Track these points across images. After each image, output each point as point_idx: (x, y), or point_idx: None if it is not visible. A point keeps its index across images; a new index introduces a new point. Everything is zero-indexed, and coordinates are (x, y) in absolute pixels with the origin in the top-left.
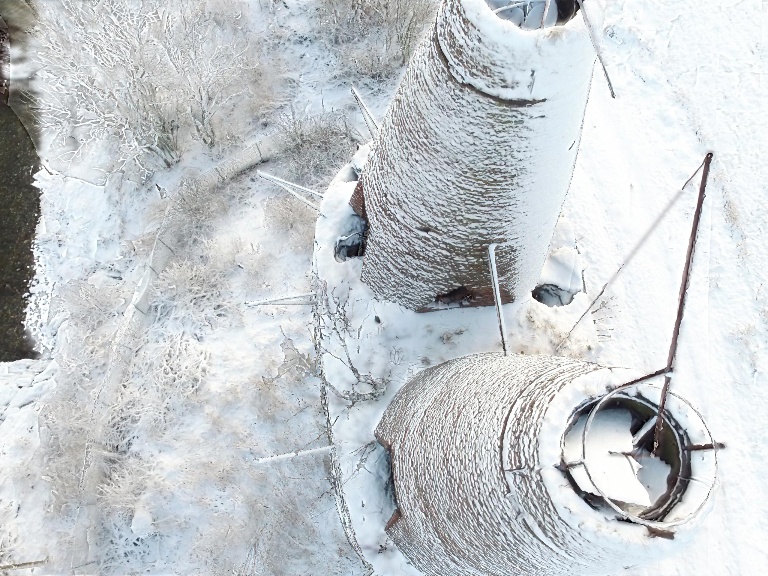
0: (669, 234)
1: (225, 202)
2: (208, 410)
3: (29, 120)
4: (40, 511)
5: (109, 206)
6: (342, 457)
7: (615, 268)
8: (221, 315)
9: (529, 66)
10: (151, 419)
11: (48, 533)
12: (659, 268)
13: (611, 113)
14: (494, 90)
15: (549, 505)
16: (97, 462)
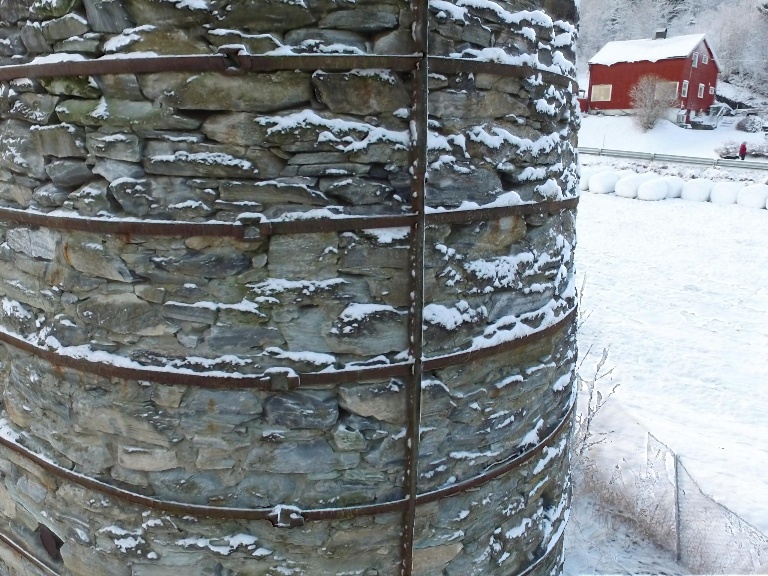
0: None
1: None
2: None
3: None
4: None
5: None
6: None
7: None
8: None
9: None
10: None
11: None
12: None
13: None
14: None
15: None
16: None
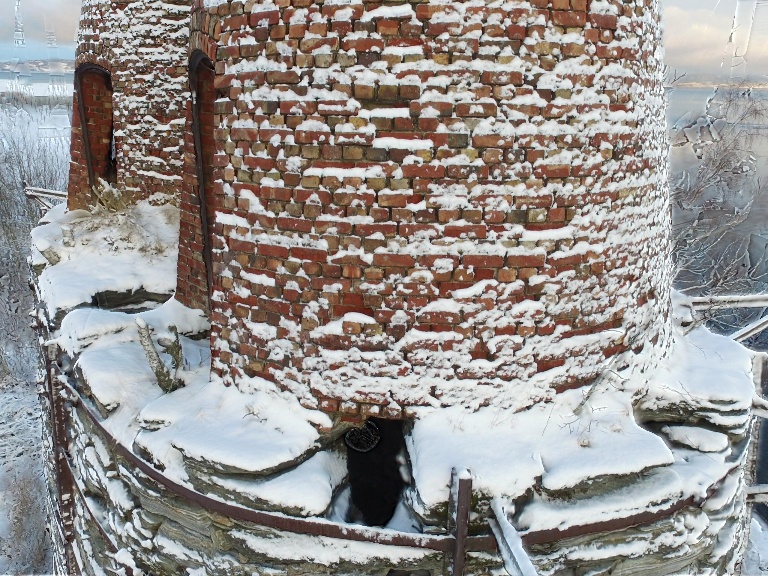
0: None
1: None
2: None
3: None
4: None
5: None
6: None
7: None
8: None
9: None
10: None
11: None
12: None
13: None
14: None
15: None
16: None
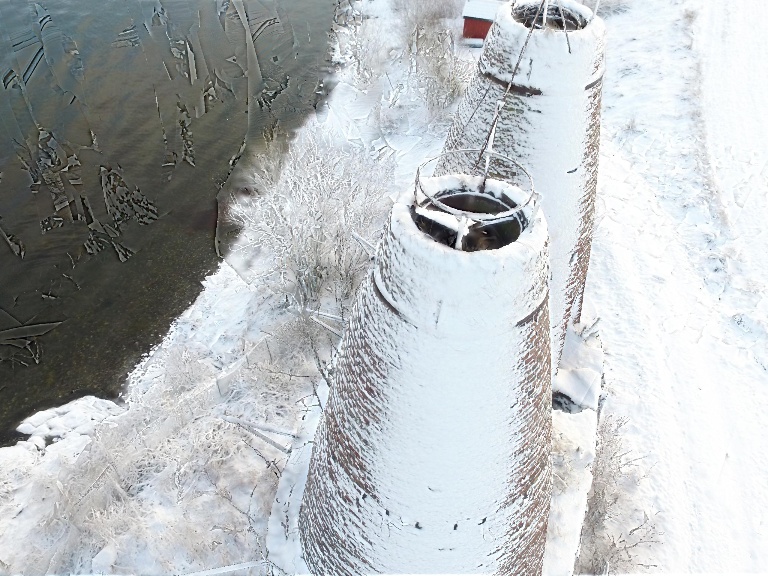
0: (761, 518)
1: (333, 337)
2: (222, 483)
3: (224, 208)
4: (34, 522)
5: (245, 314)
6: (297, 443)
7: (685, 526)
8: (280, 414)
9: (529, 54)
10: (171, 472)
11: (26, 544)
12: (740, 549)
13: (721, 383)
14: (503, 75)
15: (388, 226)
16: (106, 491)
